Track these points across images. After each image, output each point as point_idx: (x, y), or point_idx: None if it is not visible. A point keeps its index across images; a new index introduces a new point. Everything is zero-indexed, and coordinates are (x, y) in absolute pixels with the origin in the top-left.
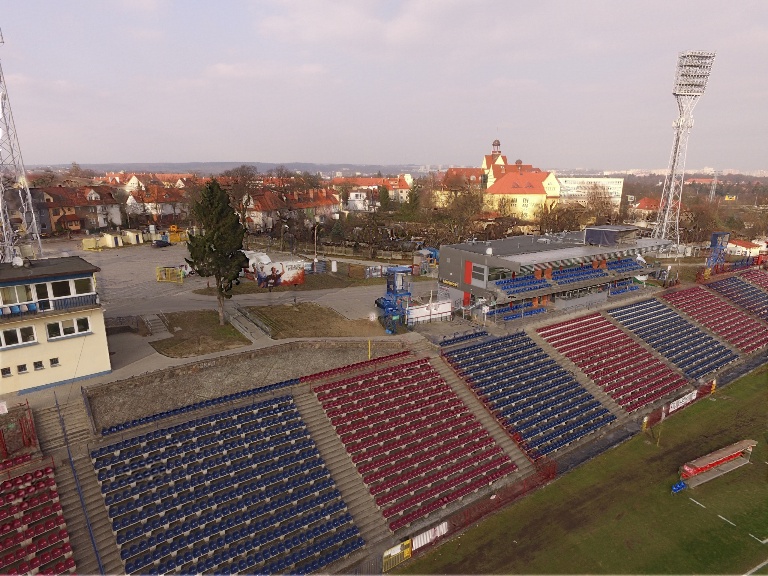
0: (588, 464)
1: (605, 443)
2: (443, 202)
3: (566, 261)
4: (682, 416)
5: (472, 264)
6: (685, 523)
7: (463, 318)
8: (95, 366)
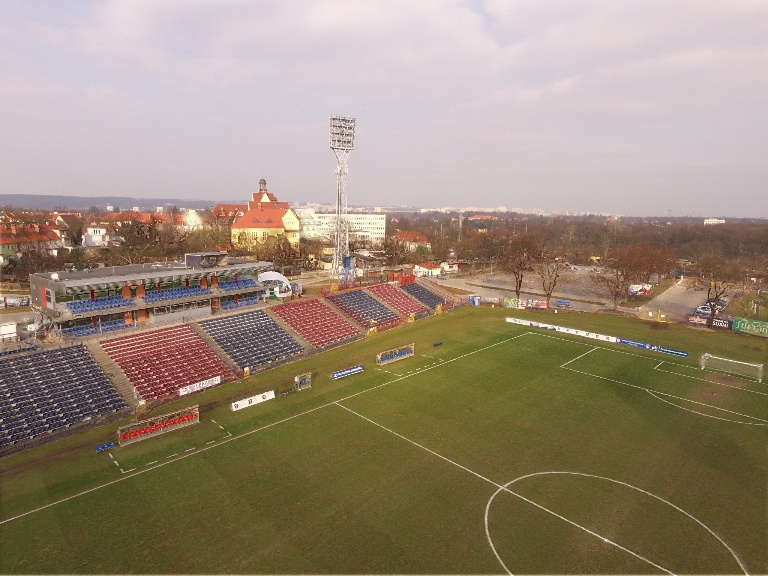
0: (51, 443)
1: (96, 426)
2: (180, 236)
3: (133, 282)
4: (194, 397)
5: (45, 289)
6: (77, 471)
7: (35, 338)
8: None
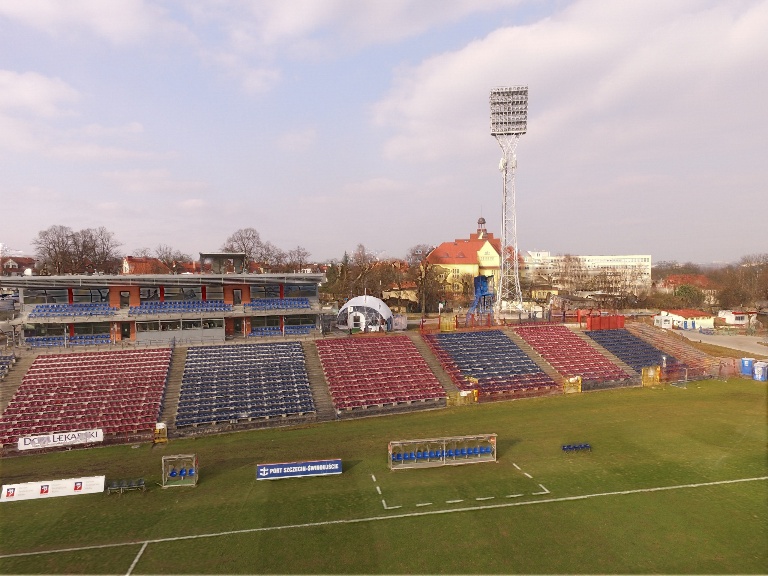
0: None
1: None
2: None
3: (94, 281)
4: (36, 457)
5: None
6: None
7: (7, 345)
8: None
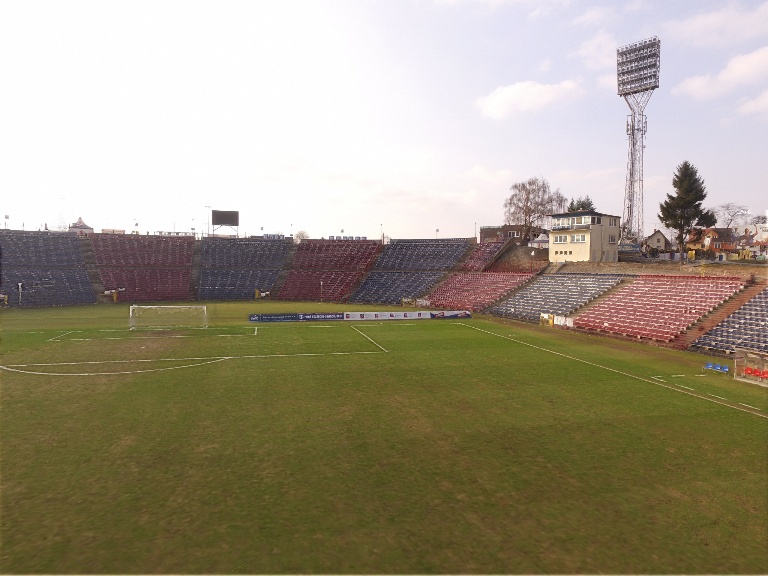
0: (721, 358)
1: None
2: None
3: None
4: None
5: None
6: None
7: None
8: None
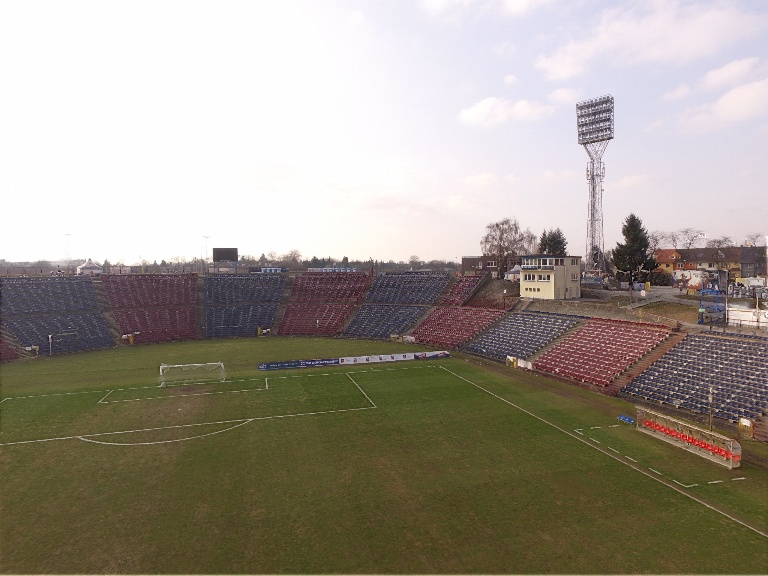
0: (638, 405)
1: None
2: None
3: None
4: None
5: None
6: (582, 416)
7: None
8: (549, 296)
